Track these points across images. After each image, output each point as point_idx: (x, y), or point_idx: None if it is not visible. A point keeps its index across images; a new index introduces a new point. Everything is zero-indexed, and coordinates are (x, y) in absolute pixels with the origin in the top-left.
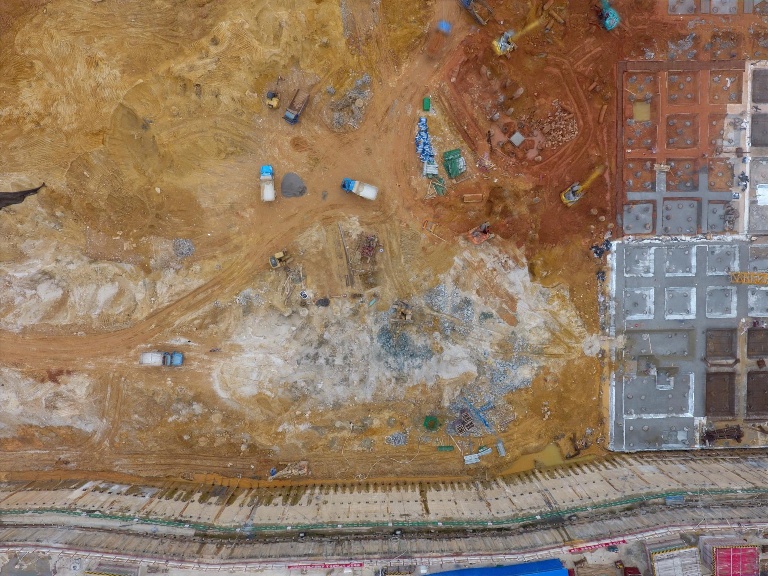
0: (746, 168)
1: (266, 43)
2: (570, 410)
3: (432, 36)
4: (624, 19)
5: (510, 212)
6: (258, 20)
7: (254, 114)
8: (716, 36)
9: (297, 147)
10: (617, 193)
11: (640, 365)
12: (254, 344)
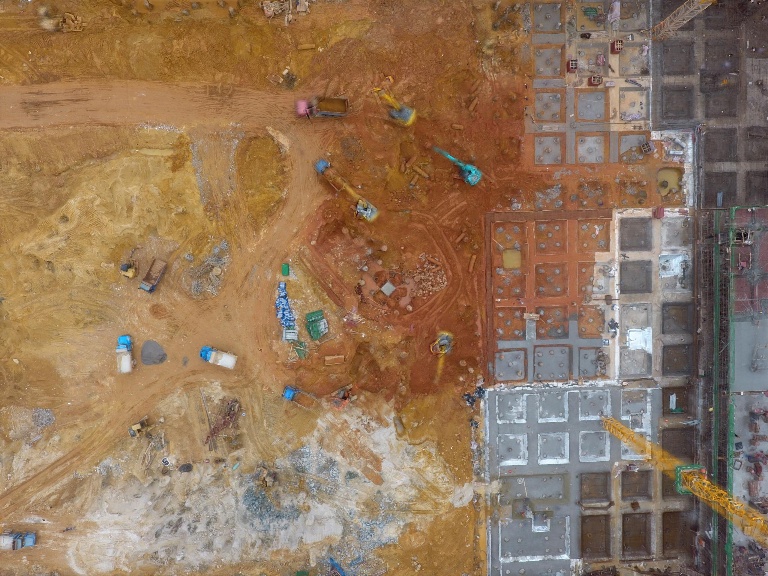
0: (616, 315)
1: (120, 215)
2: (440, 563)
3: (290, 201)
4: (489, 172)
5: (378, 366)
6: (112, 191)
7: (112, 283)
8: (583, 186)
9: (156, 314)
10: (488, 342)
11: (517, 507)
12: (109, 521)
